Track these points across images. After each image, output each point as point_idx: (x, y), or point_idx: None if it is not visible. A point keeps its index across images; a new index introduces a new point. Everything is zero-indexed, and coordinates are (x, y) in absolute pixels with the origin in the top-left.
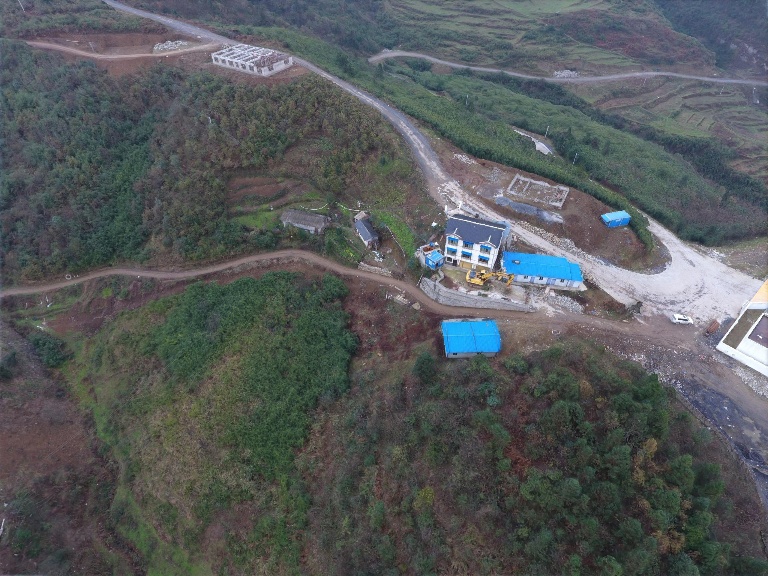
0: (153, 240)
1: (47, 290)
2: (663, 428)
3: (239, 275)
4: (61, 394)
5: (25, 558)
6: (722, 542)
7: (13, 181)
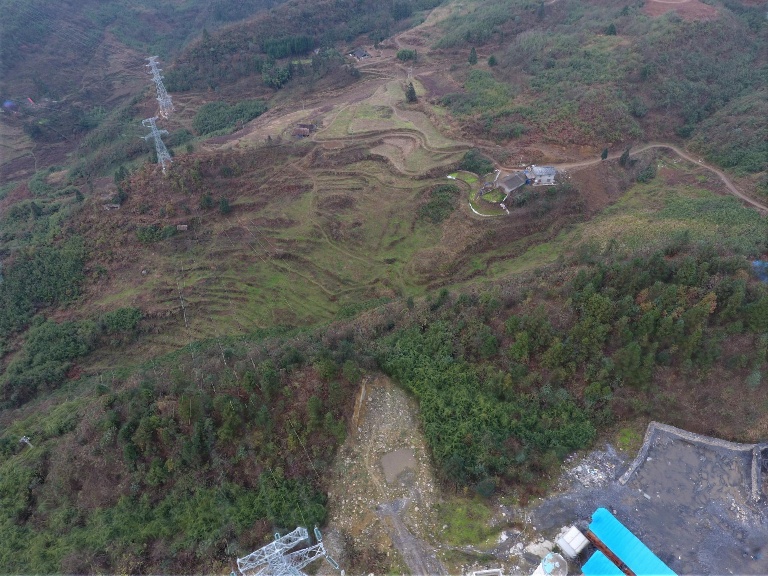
0: (759, 173)
1: (685, 158)
2: (729, 303)
3: (761, 216)
4: (623, 189)
5: (544, 197)
6: None
7: (755, 105)
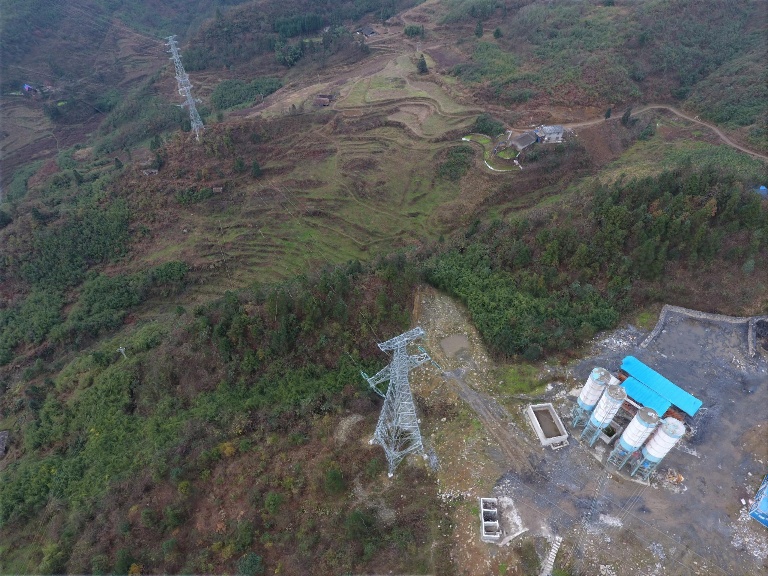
0: (750, 126)
1: (682, 116)
2: (727, 205)
3: None
4: (625, 146)
5: (554, 153)
6: None
7: (745, 66)
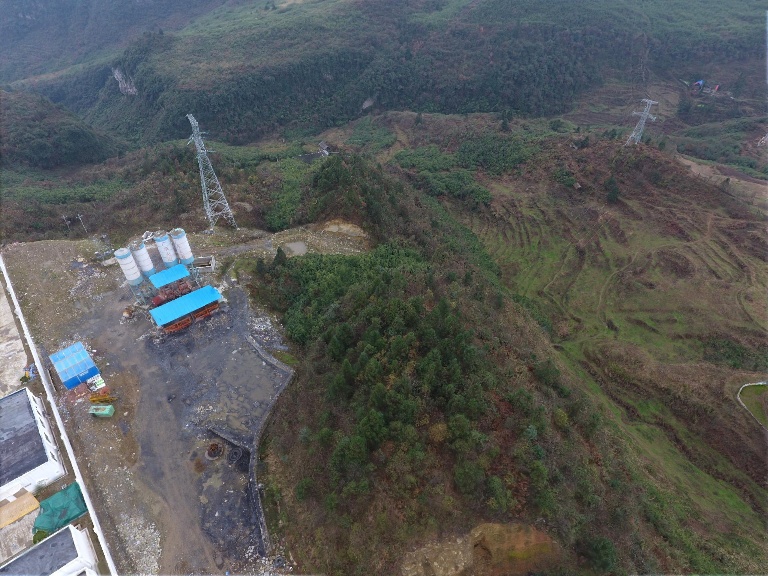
0: None
1: None
2: None
3: None
4: None
5: None
6: (353, 352)
7: None
